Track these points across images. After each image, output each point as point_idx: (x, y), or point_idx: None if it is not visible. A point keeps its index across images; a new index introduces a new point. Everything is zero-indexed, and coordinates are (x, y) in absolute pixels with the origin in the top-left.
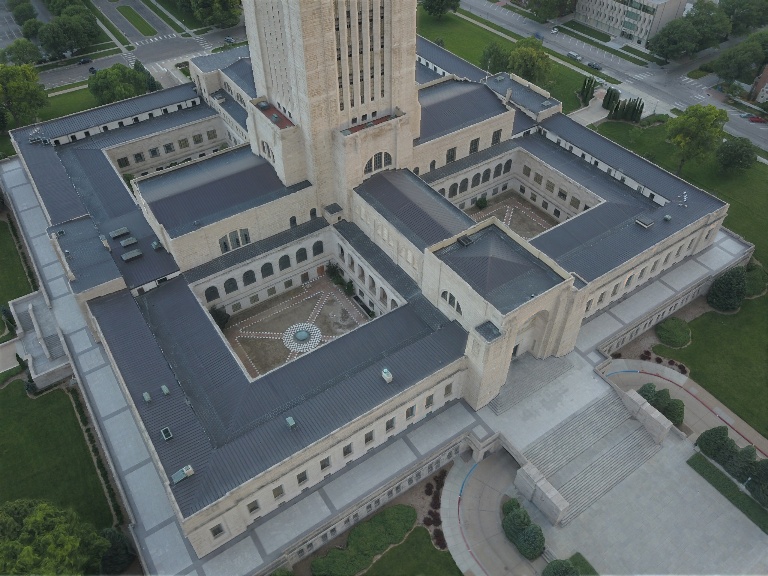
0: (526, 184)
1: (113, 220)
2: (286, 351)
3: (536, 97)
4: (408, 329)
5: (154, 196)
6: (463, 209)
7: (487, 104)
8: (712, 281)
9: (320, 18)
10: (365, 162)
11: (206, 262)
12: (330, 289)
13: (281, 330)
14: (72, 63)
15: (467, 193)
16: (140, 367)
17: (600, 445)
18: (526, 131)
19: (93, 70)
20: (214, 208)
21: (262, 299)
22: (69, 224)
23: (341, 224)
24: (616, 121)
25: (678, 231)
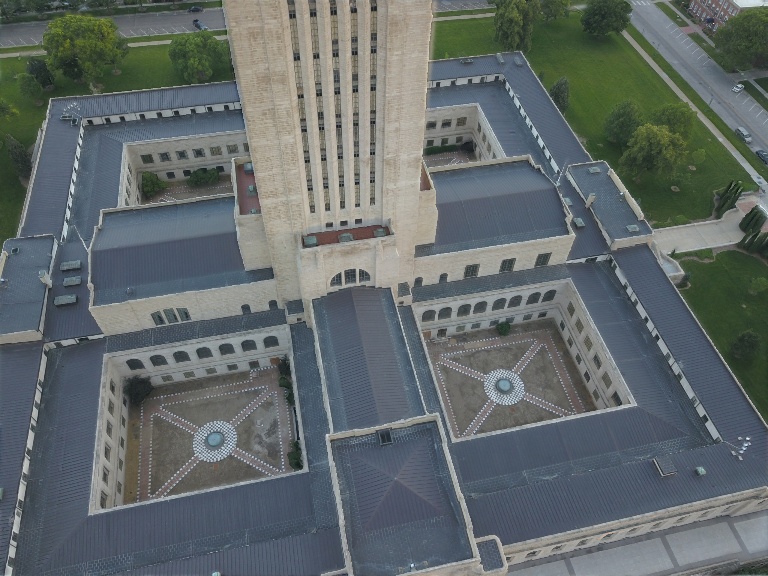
0: (566, 323)
1: (79, 244)
2: (190, 453)
3: (626, 213)
4: (290, 508)
5: (106, 241)
6: (478, 328)
7: (545, 215)
8: (738, 568)
9: (274, 119)
10: (330, 276)
11: (135, 331)
12: (276, 387)
13: (199, 423)
14: (183, 8)
15: (485, 315)
16: None
17: None
18: (590, 257)
19: (196, 23)
20: (157, 276)
21: (200, 375)
22: (29, 241)
23: (300, 326)
24: (747, 253)
25: (702, 501)
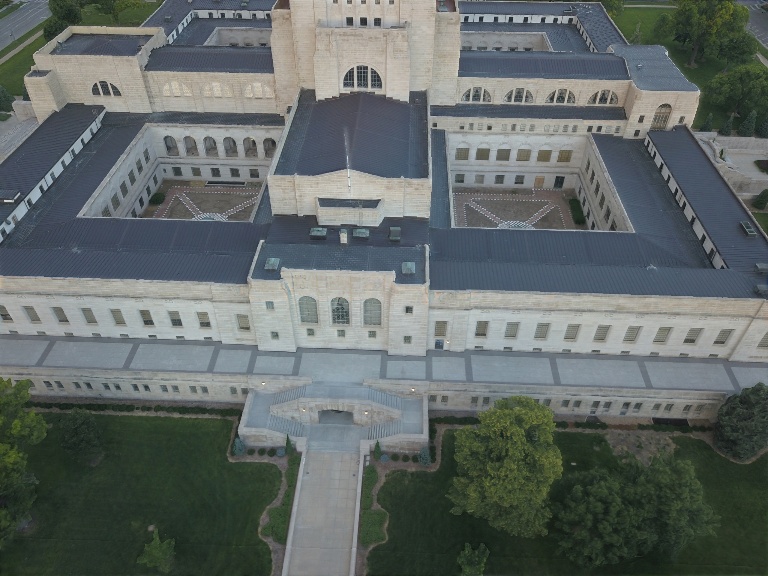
0: None
1: None
2: None
3: None
4: None
5: None
6: None
7: (314, 166)
8: None
9: None
10: None
11: None
12: None
13: None
14: None
15: None
16: (270, 4)
17: (8, 145)
18: None
19: None
20: None
21: None
22: None
23: None
24: None
25: None
